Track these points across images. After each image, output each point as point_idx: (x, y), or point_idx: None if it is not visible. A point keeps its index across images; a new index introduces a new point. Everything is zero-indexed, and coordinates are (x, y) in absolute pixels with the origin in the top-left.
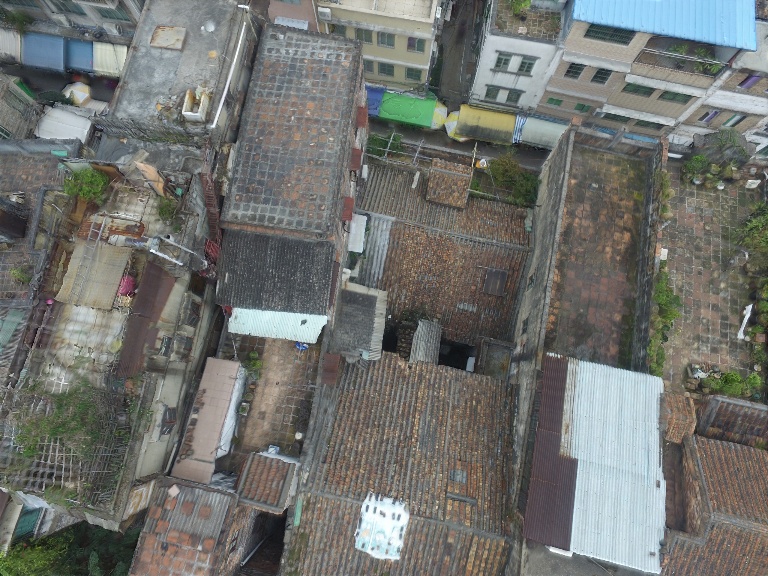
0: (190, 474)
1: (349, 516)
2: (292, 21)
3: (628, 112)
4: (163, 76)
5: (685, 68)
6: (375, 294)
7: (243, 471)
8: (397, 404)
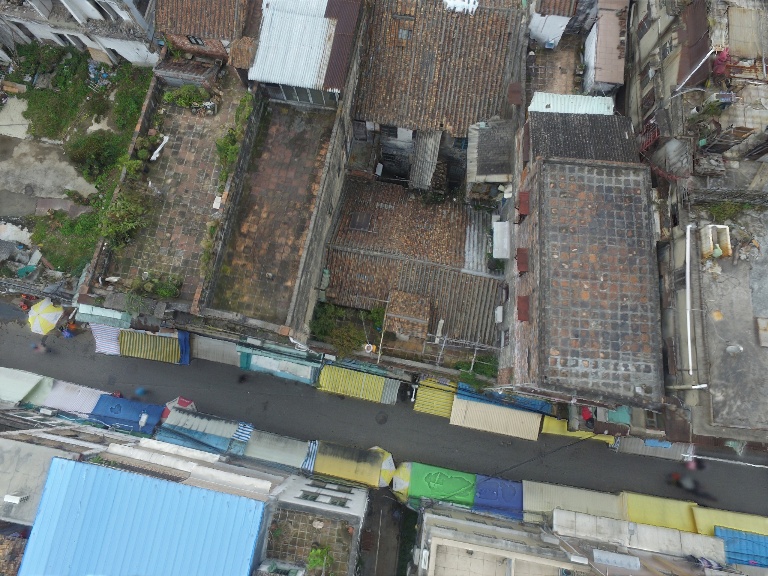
0: (615, 0)
1: (486, 2)
2: (616, 563)
3: (190, 454)
4: (765, 285)
5: (128, 469)
6: (479, 177)
7: (575, 2)
8: (453, 89)
